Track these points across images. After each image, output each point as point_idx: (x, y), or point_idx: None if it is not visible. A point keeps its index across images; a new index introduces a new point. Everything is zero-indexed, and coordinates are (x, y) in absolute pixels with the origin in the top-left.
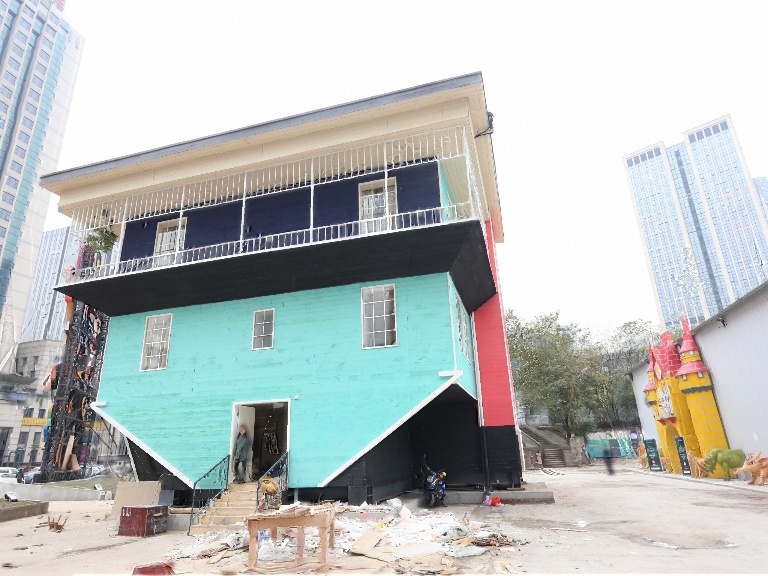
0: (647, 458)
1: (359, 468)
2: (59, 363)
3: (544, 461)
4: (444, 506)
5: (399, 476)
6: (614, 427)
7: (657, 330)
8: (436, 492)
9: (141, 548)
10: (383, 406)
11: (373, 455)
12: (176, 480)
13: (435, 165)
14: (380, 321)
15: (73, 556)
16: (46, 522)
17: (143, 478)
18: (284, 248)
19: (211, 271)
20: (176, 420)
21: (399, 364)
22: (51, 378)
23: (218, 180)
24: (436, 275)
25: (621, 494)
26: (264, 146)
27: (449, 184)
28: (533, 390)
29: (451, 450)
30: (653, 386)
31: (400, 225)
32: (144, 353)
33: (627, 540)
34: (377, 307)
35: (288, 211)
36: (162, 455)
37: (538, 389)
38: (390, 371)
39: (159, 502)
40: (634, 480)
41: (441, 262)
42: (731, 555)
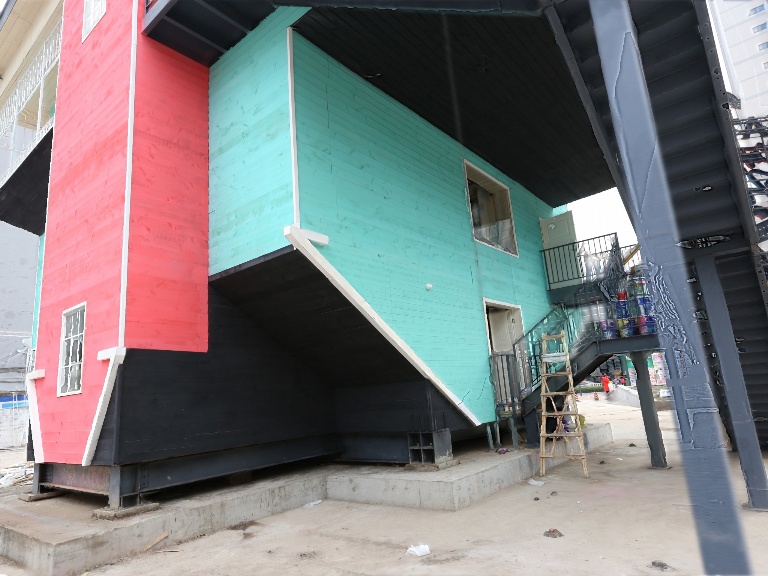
0: None
1: None
2: None
3: None
4: None
5: None
6: None
7: None
8: None
9: None
10: None
11: None
12: None
13: None
14: None
15: None
16: None
17: None
18: None
19: None
20: None
21: None
22: None
23: None
24: None
25: None
26: None
27: None
28: None
29: None
30: None
31: None
32: None
33: None
34: None
35: None
36: None
37: None
38: None
39: None
40: None
41: None
42: None
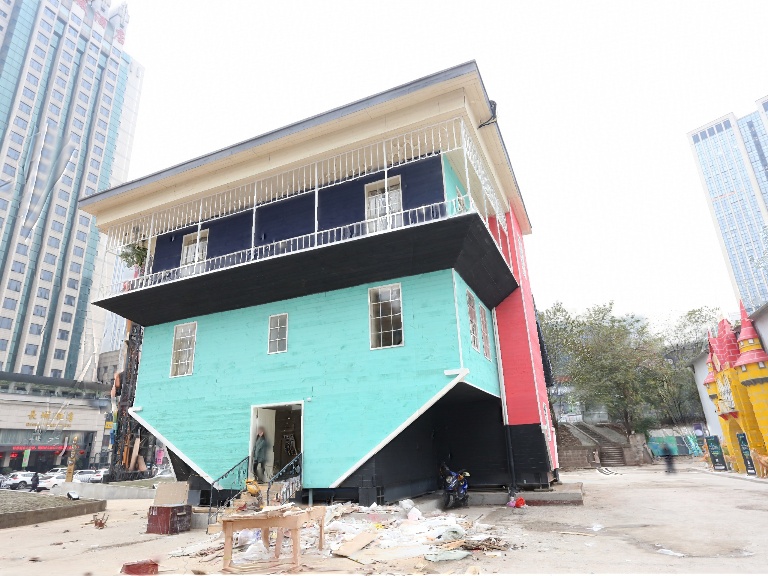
0: (710, 456)
1: (369, 469)
2: (122, 371)
3: (602, 460)
4: (466, 507)
5: (420, 476)
6: (677, 423)
7: (726, 317)
8: (455, 493)
9: (157, 545)
10: (391, 406)
11: (385, 456)
12: (202, 481)
13: (439, 160)
14: (387, 321)
15: (94, 552)
16: (97, 519)
17: (180, 478)
18: (290, 253)
19: (227, 279)
20: (201, 423)
21: (406, 364)
22: (115, 385)
23: (231, 191)
24: (441, 272)
25: (662, 495)
26: (271, 155)
27: (459, 178)
28: (585, 386)
29: (476, 450)
30: (713, 378)
31: (400, 223)
32: (173, 360)
33: (633, 546)
34: (384, 307)
35: (299, 217)
36: (190, 457)
37: (591, 384)
38: (397, 371)
39: (188, 501)
40: (690, 480)
41: (445, 258)
42: (737, 565)
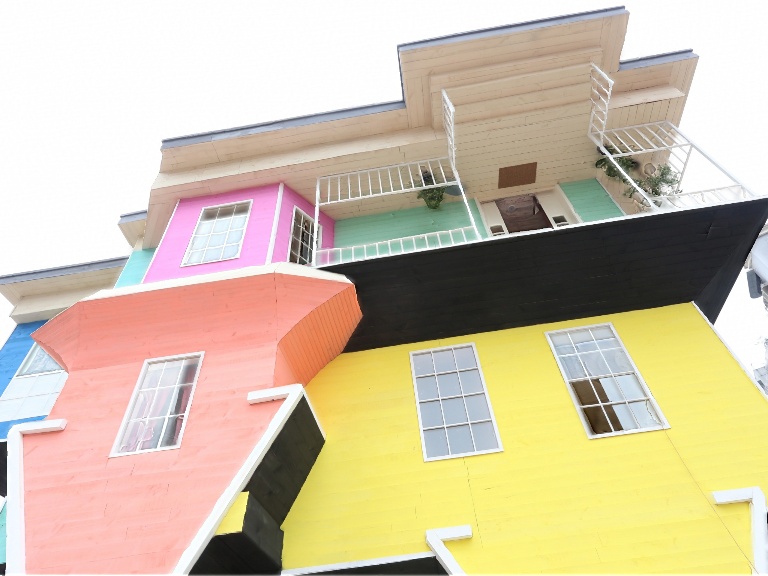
0: None
1: None
2: None
3: None
4: None
5: None
6: None
7: None
8: None
9: None
10: None
11: None
12: None
13: None
14: None
15: None
16: None
17: None
18: None
19: None
20: None
21: None
22: None
23: None
24: None
25: None
26: None
27: None
28: None
29: None
30: None
31: None
32: None
33: None
34: None
35: None
36: None
37: None
38: None
39: None
40: None
41: None
42: None
